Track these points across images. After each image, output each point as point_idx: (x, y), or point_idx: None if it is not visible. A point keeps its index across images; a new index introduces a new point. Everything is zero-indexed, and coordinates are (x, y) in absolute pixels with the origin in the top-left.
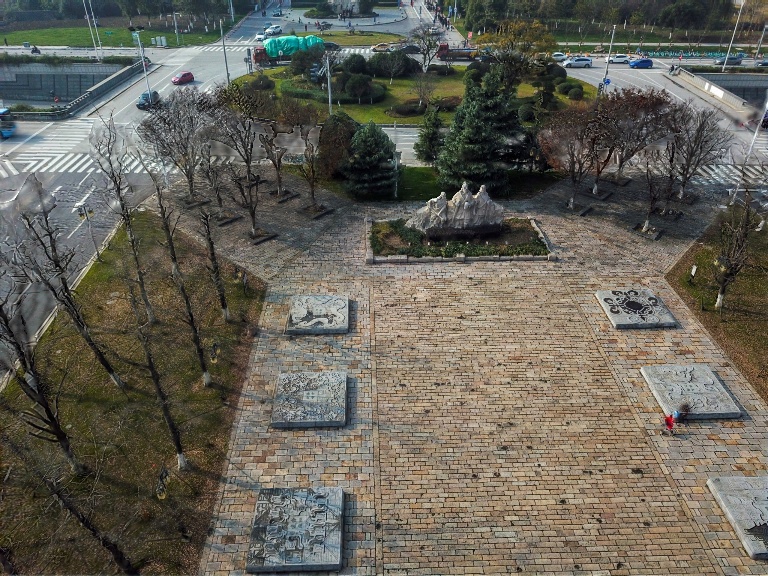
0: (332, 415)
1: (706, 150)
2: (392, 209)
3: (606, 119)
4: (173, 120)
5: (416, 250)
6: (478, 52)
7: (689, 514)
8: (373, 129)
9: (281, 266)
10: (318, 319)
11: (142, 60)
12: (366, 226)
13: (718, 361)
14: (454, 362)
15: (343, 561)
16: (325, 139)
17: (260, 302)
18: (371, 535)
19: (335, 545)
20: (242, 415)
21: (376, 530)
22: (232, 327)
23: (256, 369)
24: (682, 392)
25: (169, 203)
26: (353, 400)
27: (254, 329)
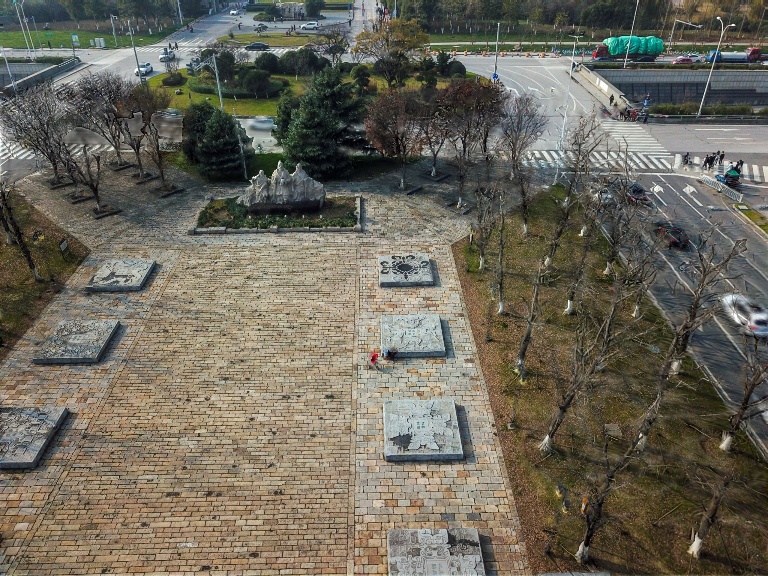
0: (87, 353)
1: (529, 134)
2: (238, 189)
3: (446, 107)
4: (29, 107)
5: (236, 223)
6: (357, 48)
7: (354, 428)
8: (219, 116)
9: (110, 236)
10: (117, 278)
11: (3, 53)
12: (204, 203)
13: (455, 312)
14: (221, 313)
15: (40, 461)
16: (186, 126)
17: (76, 266)
18: (75, 443)
19: (36, 449)
20: (13, 354)
21: (81, 439)
22: (39, 285)
23: (44, 319)
24: (403, 336)
25: (0, 178)
26: (116, 343)
27: (59, 287)
